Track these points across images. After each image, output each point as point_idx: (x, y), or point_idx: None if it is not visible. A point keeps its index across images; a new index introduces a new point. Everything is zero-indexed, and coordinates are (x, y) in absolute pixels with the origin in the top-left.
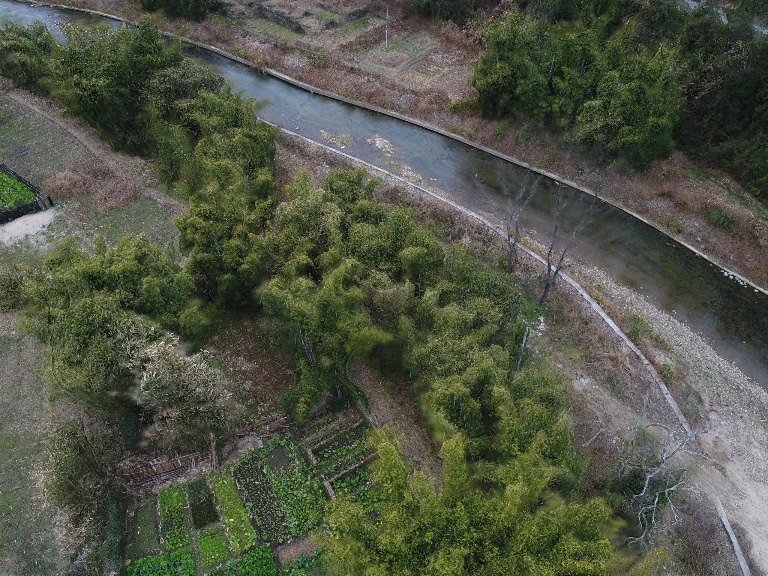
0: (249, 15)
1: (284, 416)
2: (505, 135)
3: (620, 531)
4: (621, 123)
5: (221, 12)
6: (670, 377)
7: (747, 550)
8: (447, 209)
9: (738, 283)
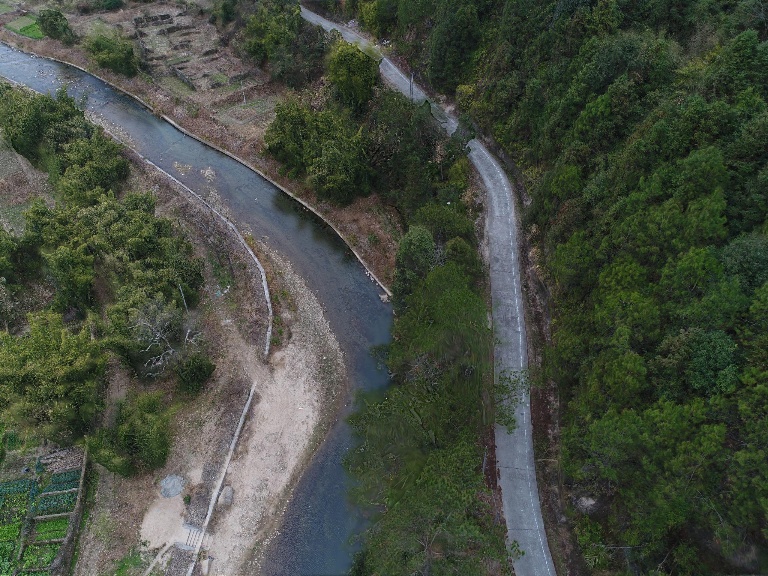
0: (166, 74)
1: None
2: (284, 174)
3: (182, 384)
4: (327, 173)
5: (147, 71)
6: (278, 323)
7: (253, 404)
8: (209, 219)
9: (370, 279)
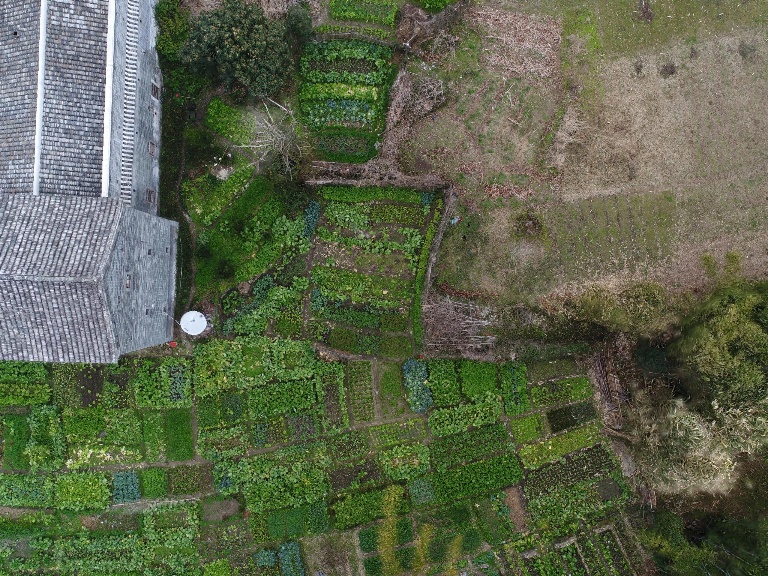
0: None
1: (654, 506)
2: None
3: None
4: None
5: None
6: None
7: None
8: None
9: None
